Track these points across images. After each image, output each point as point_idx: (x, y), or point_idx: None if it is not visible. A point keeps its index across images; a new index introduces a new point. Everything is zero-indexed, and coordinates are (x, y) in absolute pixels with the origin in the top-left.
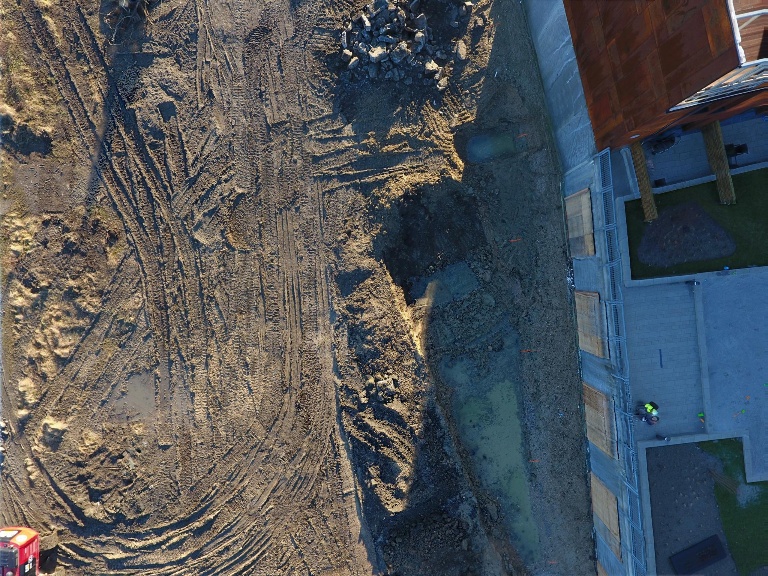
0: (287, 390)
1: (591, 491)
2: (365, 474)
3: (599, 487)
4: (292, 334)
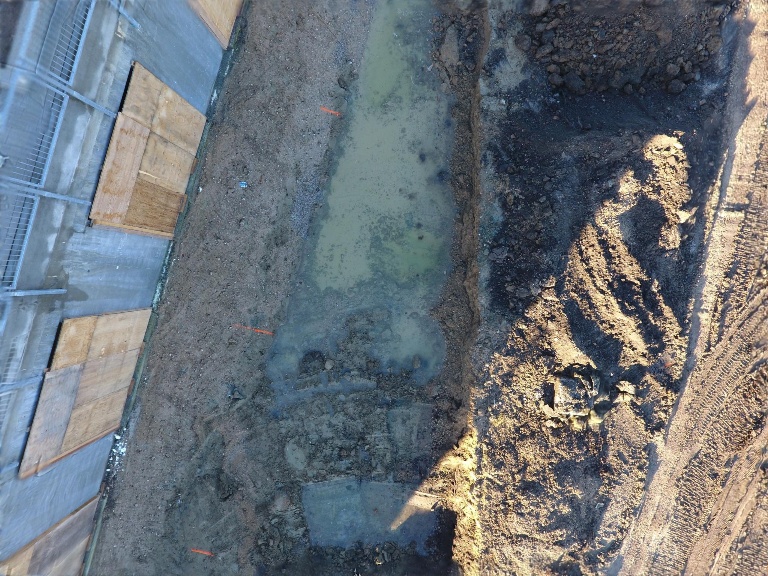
0: (765, 464)
1: (241, 7)
2: (688, 236)
3: (218, 11)
4: (707, 567)
